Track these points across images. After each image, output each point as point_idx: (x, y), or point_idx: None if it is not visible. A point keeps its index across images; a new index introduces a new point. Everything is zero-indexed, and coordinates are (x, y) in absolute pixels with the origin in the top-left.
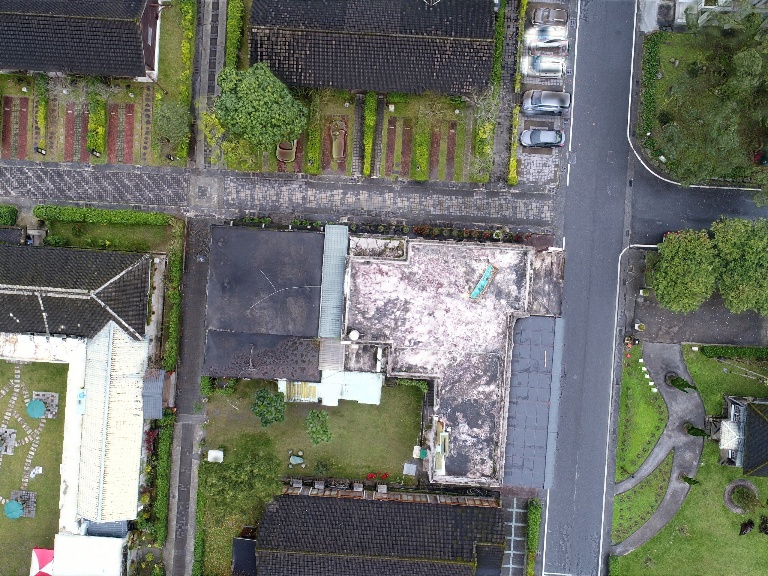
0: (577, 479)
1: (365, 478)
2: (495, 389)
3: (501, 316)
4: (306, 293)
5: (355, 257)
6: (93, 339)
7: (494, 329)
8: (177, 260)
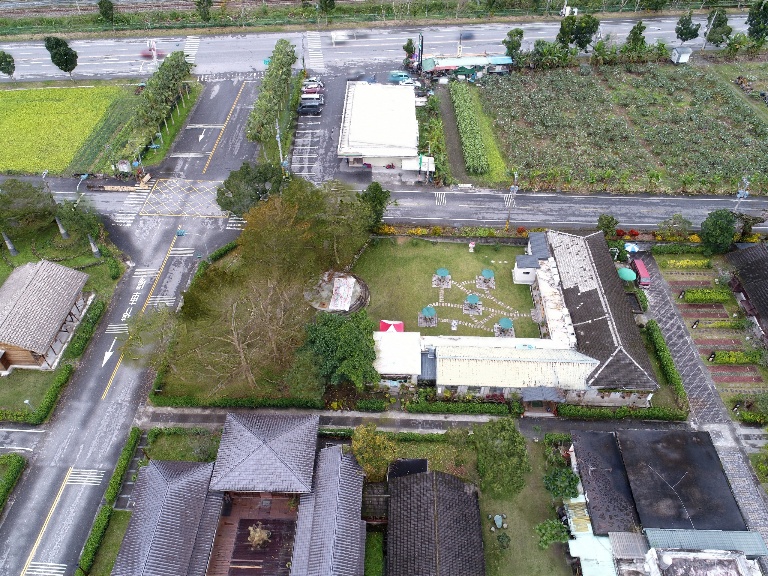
0: None
1: None
2: None
3: None
4: (682, 516)
5: (746, 560)
6: (577, 352)
7: None
8: (656, 412)
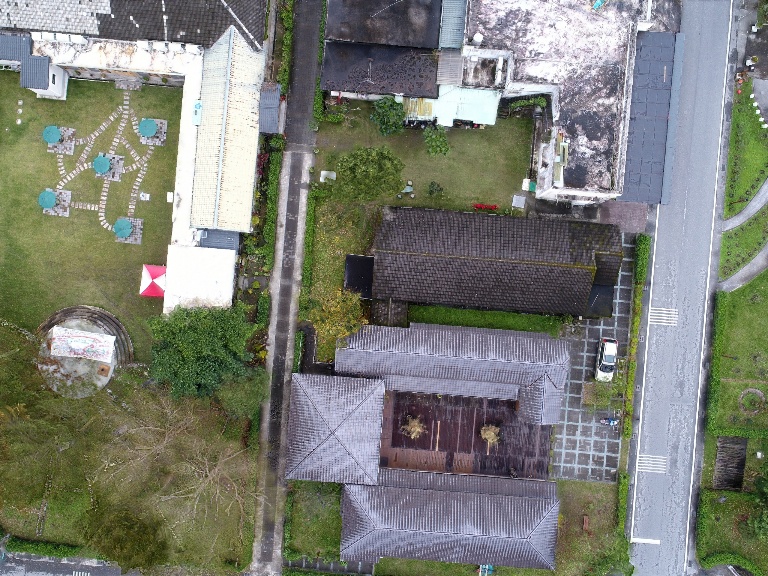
0: (686, 214)
1: (474, 210)
2: (615, 102)
3: (622, 28)
4: (427, 4)
5: None
6: (211, 49)
7: (615, 41)
8: None
